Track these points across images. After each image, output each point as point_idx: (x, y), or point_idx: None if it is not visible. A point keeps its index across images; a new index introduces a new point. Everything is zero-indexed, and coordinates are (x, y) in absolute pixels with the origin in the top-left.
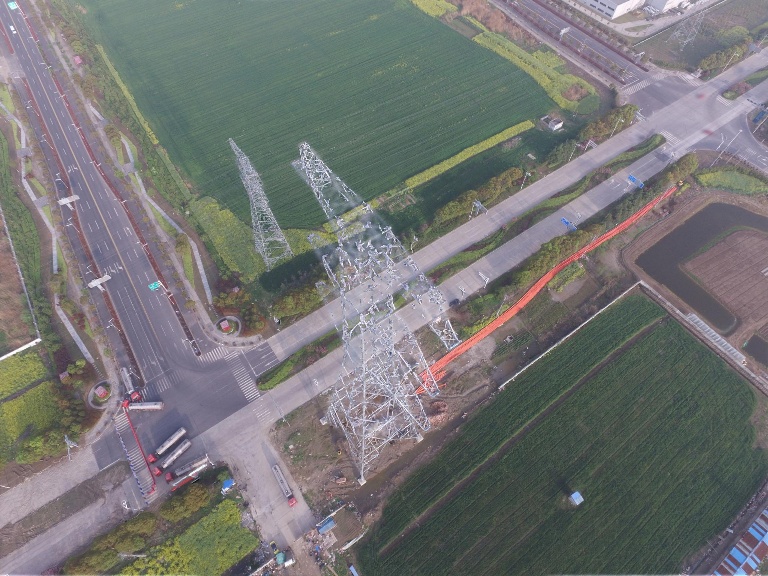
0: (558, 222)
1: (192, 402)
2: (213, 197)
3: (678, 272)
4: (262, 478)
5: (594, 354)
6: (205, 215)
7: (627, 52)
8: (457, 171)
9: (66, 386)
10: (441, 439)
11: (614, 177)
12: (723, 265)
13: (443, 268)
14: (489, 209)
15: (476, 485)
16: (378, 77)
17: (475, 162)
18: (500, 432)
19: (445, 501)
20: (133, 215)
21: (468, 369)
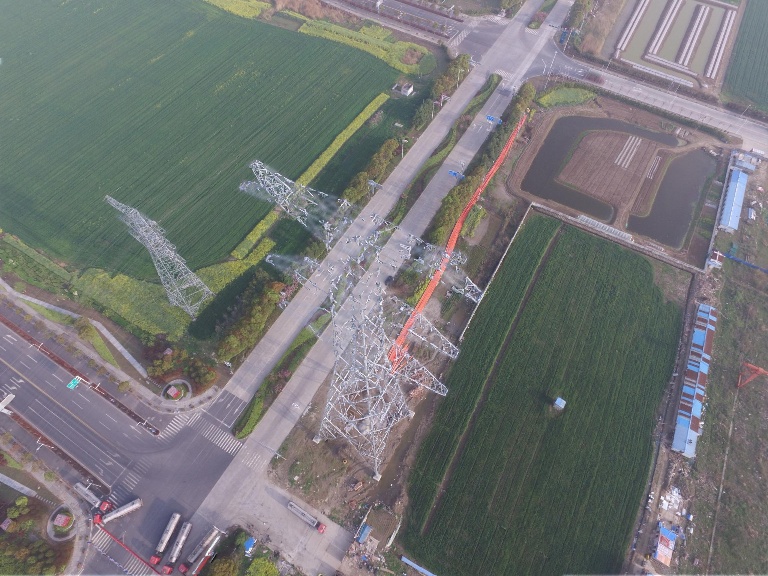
0: (446, 176)
1: (172, 483)
2: (97, 267)
3: (556, 185)
4: (281, 521)
5: (522, 278)
6: (97, 289)
7: (440, 9)
8: (338, 159)
9: (15, 534)
10: (430, 406)
11: (474, 122)
12: (586, 167)
13: (365, 253)
14: (382, 185)
15: (477, 432)
16: (222, 92)
17: (351, 146)
18: (477, 377)
19: (457, 458)
20: (8, 319)
21: (426, 334)
